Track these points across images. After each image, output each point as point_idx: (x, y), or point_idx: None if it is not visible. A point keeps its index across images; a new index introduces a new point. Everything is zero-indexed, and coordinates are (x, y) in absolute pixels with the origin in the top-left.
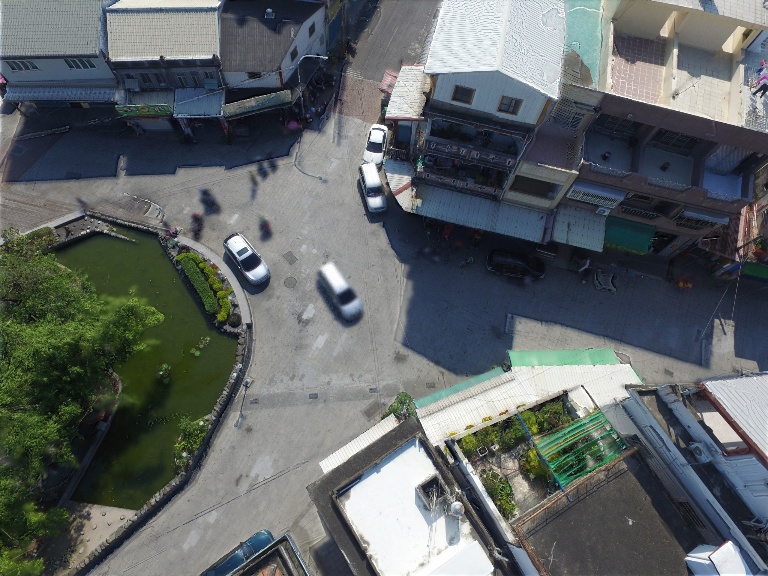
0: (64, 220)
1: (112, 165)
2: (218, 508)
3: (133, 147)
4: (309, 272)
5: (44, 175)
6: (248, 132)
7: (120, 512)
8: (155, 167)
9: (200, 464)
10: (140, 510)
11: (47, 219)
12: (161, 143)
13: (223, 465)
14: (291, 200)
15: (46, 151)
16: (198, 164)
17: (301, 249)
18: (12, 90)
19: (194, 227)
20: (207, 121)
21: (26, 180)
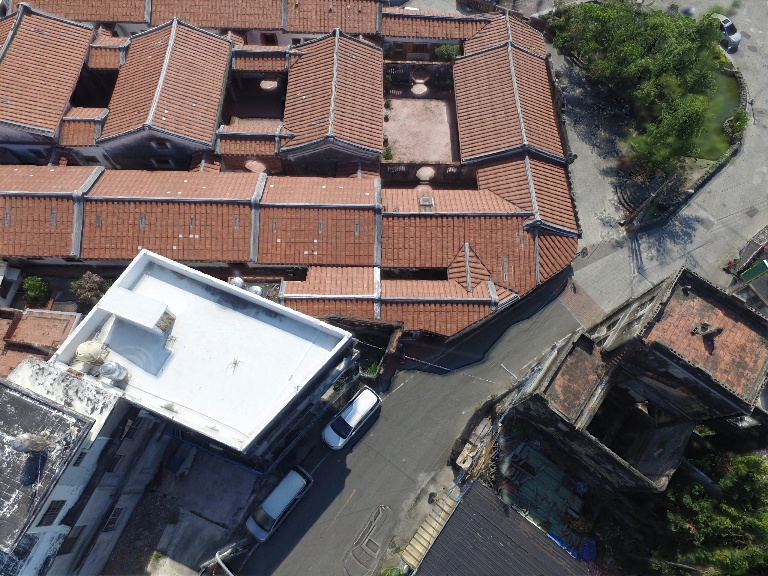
0: (579, 3)
1: None
2: (766, 165)
3: None
4: (763, 43)
5: None
6: None
7: (705, 161)
8: None
9: (740, 143)
10: None
11: None
12: None
13: (757, 144)
14: (728, 1)
15: None
16: None
17: (750, 30)
18: None
19: None
20: None
21: None
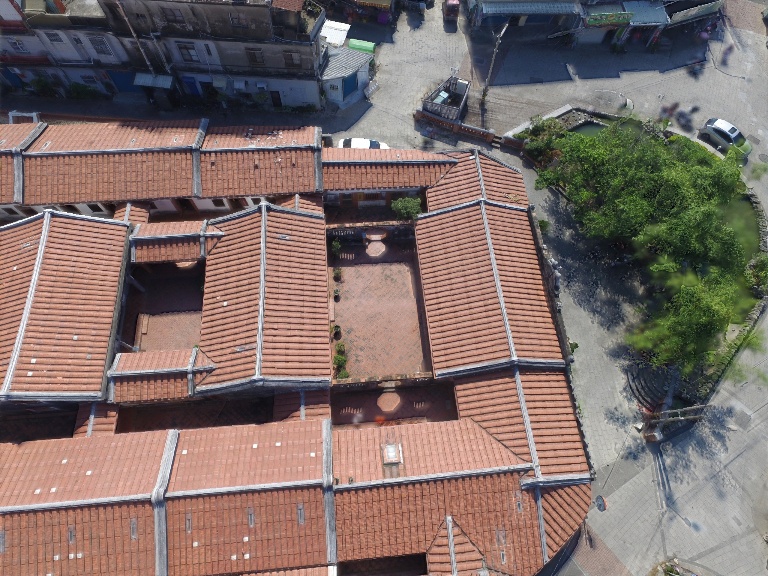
0: (559, 112)
1: (564, 71)
2: None
3: (573, 57)
4: None
5: (512, 80)
6: (669, 42)
7: (729, 326)
8: (601, 72)
9: None
10: (746, 323)
11: (539, 113)
12: (594, 53)
13: None
14: (729, 95)
15: (503, 61)
16: (635, 69)
17: (759, 133)
18: (488, 6)
19: (660, 118)
20: (637, 32)
21: (500, 84)
